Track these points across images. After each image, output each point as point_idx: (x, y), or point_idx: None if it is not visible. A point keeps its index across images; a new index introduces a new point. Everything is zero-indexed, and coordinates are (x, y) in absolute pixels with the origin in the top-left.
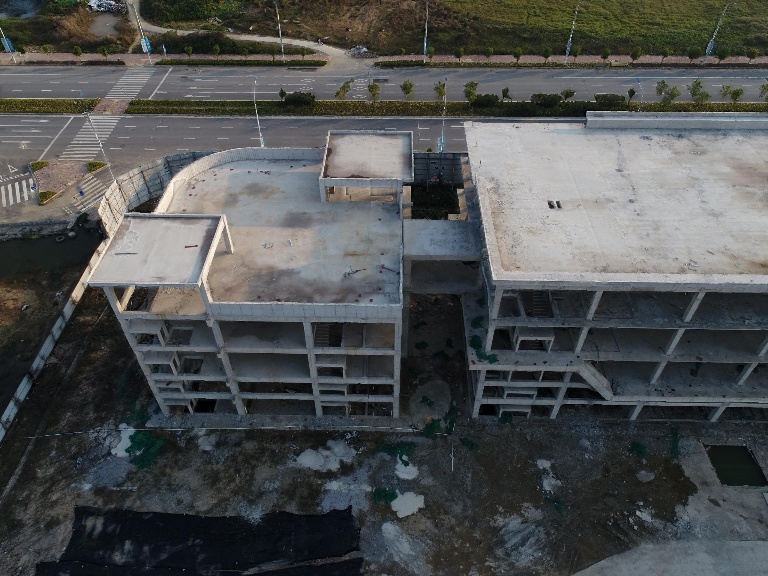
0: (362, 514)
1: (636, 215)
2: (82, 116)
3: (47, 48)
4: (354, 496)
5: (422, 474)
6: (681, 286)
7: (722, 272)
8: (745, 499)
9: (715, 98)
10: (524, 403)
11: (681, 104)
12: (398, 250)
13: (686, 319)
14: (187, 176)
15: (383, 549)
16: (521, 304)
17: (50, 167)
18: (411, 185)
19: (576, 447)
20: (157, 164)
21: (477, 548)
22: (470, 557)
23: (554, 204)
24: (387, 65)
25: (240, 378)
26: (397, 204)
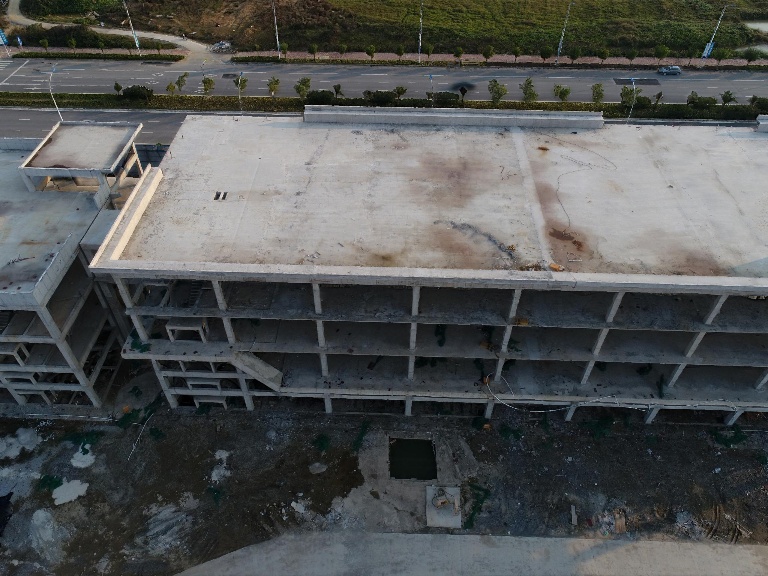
0: (20, 501)
1: (293, 207)
2: None
3: None
4: (19, 483)
5: (97, 463)
6: (275, 276)
7: (338, 264)
8: (406, 492)
9: (554, 98)
10: (213, 394)
11: (516, 103)
12: (77, 239)
13: (316, 311)
14: None
15: (25, 535)
16: (166, 294)
17: None
18: None
19: (261, 438)
20: None
21: (119, 536)
22: (108, 544)
23: (220, 195)
24: (242, 61)
25: None
26: None
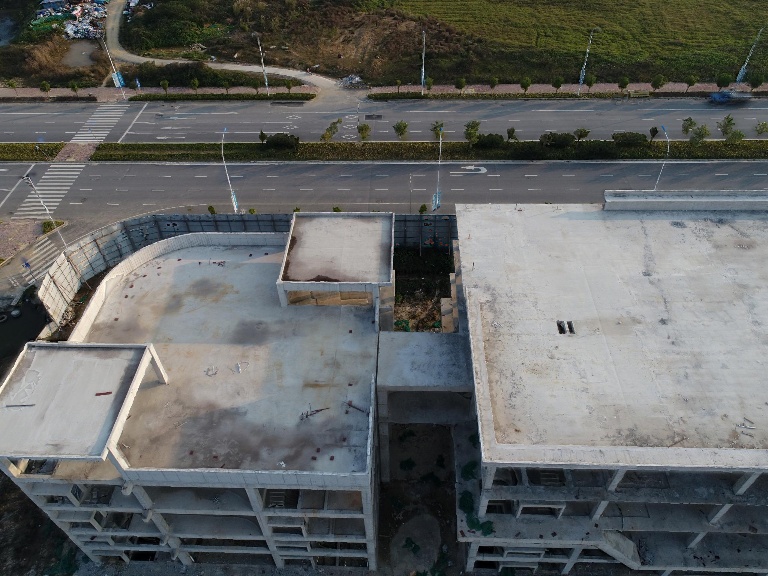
0: None
1: (670, 344)
2: (43, 164)
3: (15, 82)
4: None
5: None
6: None
7: None
8: None
9: (749, 134)
10: (529, 560)
11: (710, 143)
12: (370, 379)
13: (738, 492)
14: (125, 271)
15: None
16: None
17: (1, 227)
18: (402, 249)
19: None
20: (113, 230)
21: None
22: None
23: (565, 327)
24: (381, 98)
25: (178, 535)
26: (373, 309)
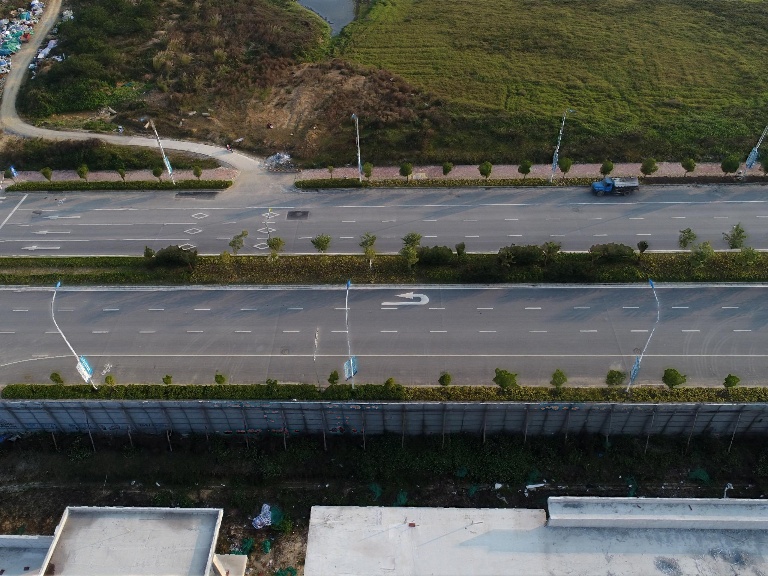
0: None
1: None
2: None
3: None
4: None
5: None
6: None
7: None
8: None
9: (763, 242)
10: None
11: (715, 257)
12: None
13: None
14: None
15: None
16: None
17: None
18: (301, 440)
19: None
20: None
21: None
22: None
23: None
24: (310, 186)
25: None
26: None
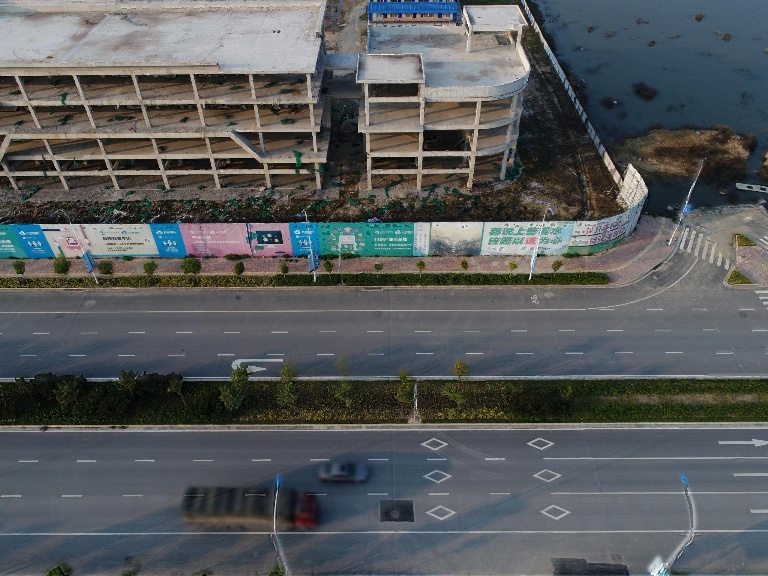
0: None
1: None
2: None
3: None
4: None
5: None
6: None
7: (214, 13)
8: None
9: None
10: None
11: None
12: None
13: None
14: None
15: None
16: None
17: None
18: None
19: None
20: None
21: None
22: None
23: None
24: None
25: None
26: None
